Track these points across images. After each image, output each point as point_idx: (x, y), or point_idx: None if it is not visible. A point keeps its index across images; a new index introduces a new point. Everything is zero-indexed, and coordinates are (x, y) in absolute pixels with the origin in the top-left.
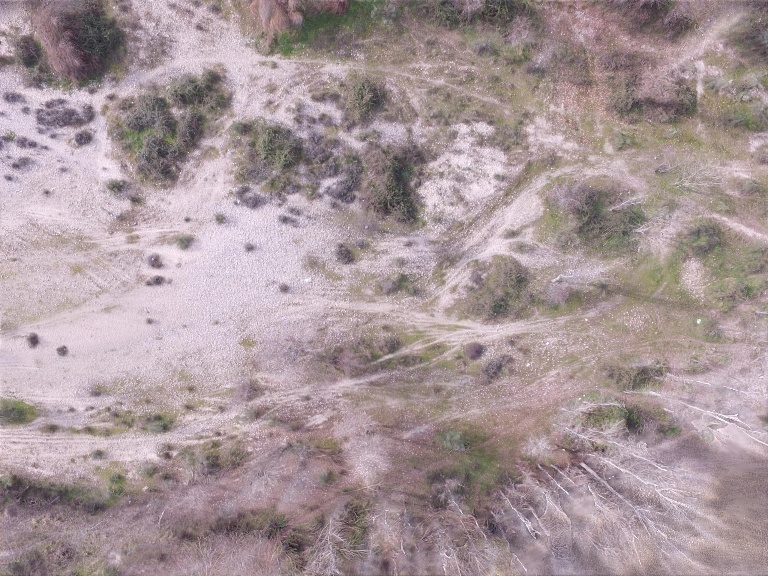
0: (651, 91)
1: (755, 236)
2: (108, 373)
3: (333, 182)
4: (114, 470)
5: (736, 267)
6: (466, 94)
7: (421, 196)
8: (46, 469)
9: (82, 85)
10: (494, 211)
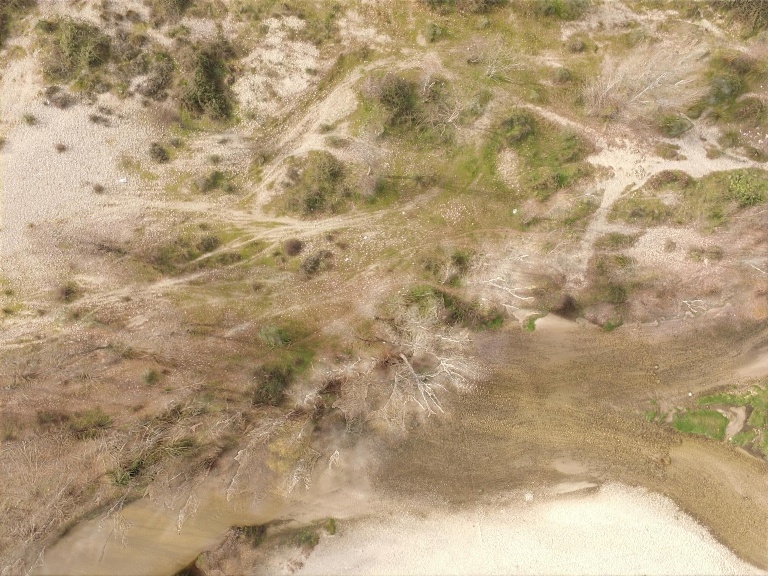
0: None
1: (569, 125)
2: None
3: (143, 80)
4: None
5: (550, 156)
6: None
7: (235, 93)
8: None
9: None
10: (308, 106)
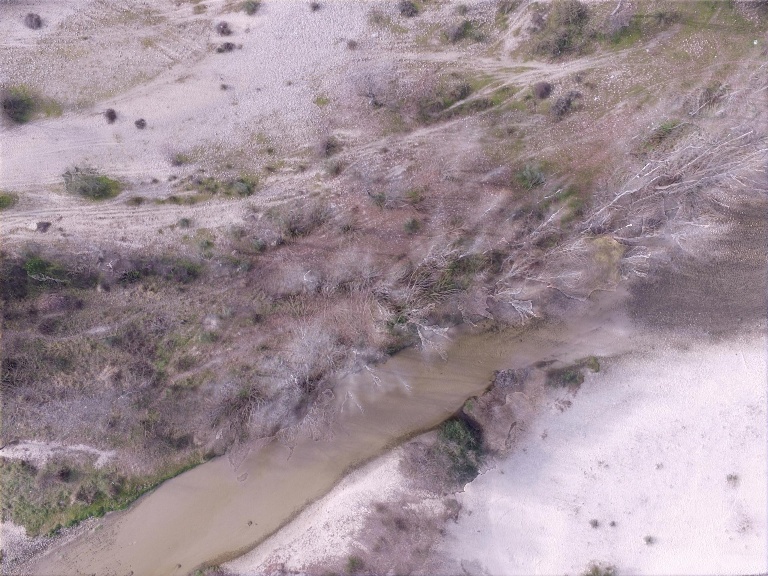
0: None
1: None
2: (187, 142)
3: None
4: (202, 237)
5: None
6: None
7: None
8: (134, 242)
9: None
10: None
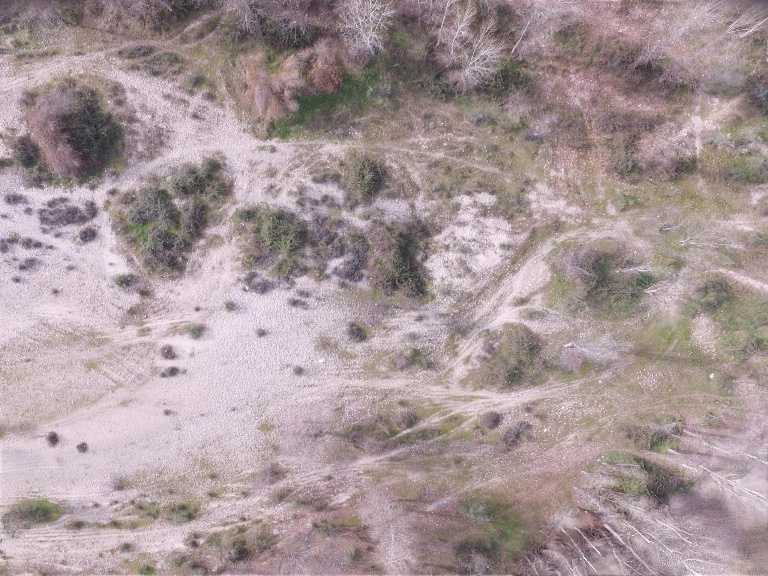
0: (650, 150)
1: (762, 287)
2: (129, 467)
3: (340, 262)
4: (142, 562)
5: (745, 320)
6: (466, 165)
7: (428, 270)
8: (75, 565)
9: (83, 182)
10: (502, 280)
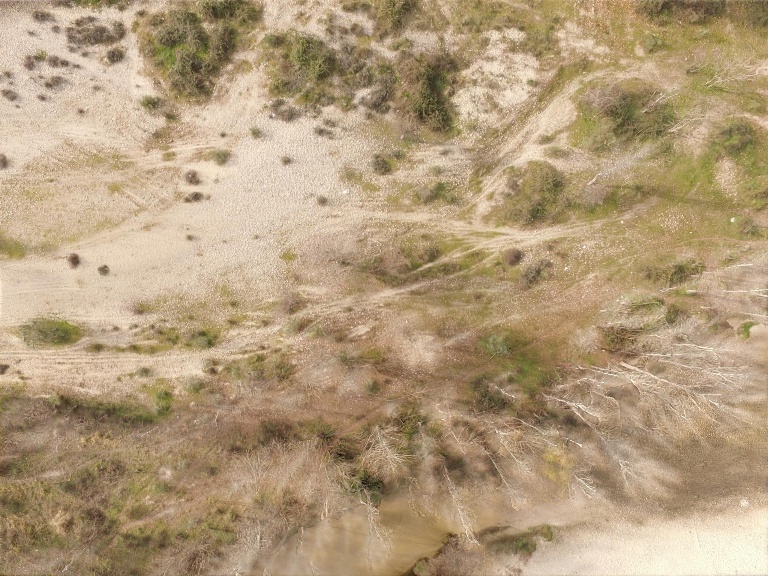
0: None
1: None
2: (150, 291)
3: (367, 92)
4: (160, 387)
5: (767, 165)
6: (497, 0)
7: (455, 105)
8: (93, 388)
9: (111, 2)
10: (528, 117)
